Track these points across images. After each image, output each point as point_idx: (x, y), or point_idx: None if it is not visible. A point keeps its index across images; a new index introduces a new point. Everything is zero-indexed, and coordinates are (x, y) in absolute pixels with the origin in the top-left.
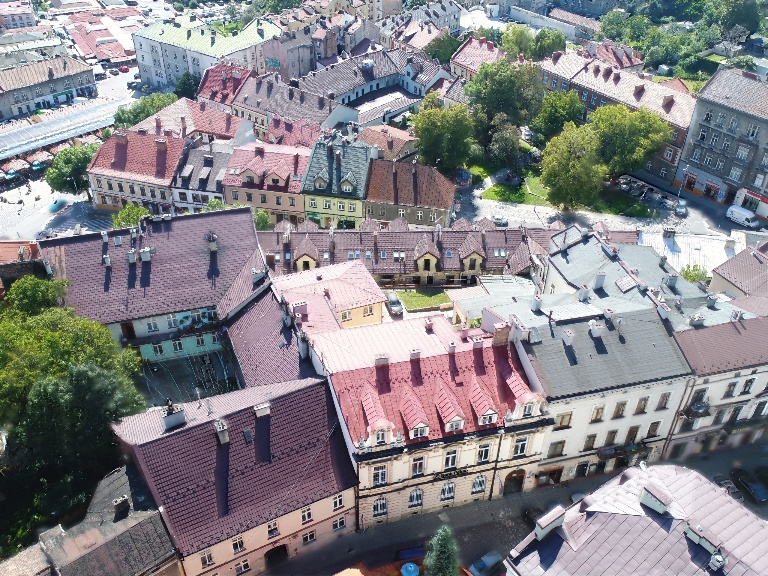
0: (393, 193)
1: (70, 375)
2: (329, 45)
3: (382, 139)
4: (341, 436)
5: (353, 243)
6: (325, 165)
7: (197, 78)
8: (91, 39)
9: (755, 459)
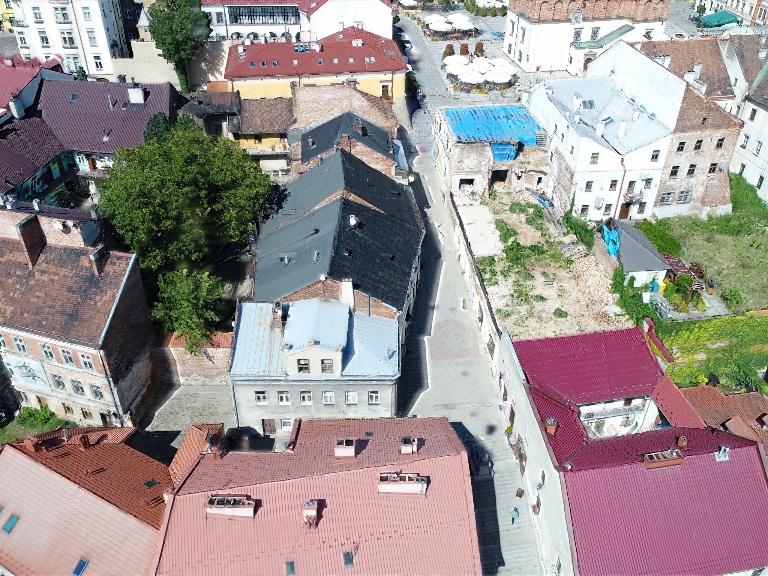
0: None
1: None
2: None
3: None
4: None
5: None
6: None
7: None
8: None
9: None
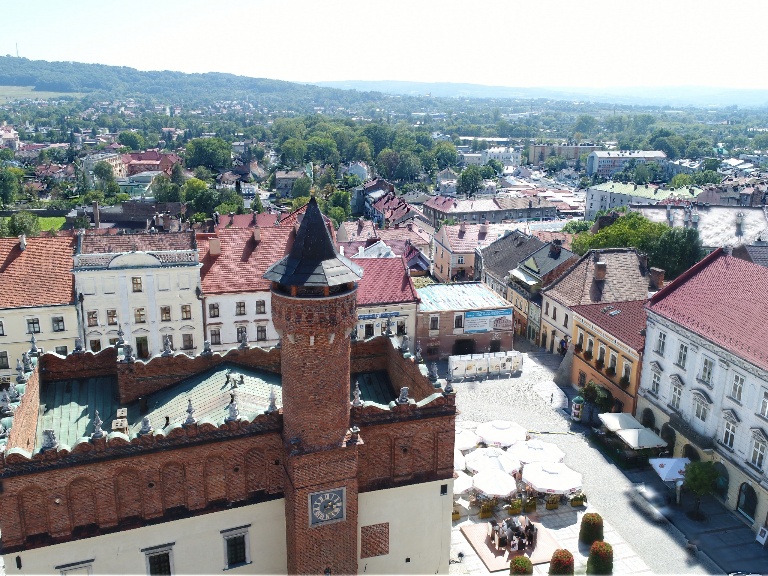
0: None
1: (684, 232)
2: (755, 199)
3: None
4: None
5: None
6: None
7: None
8: None
9: None
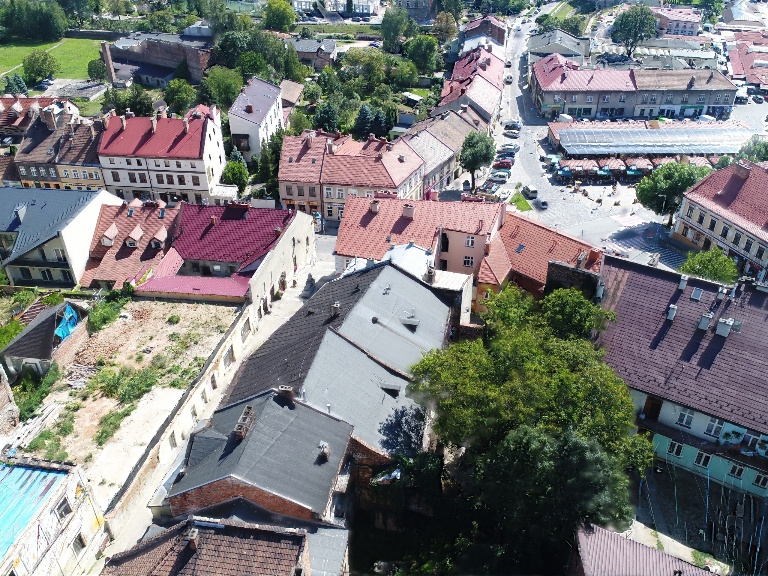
0: None
1: (564, 440)
2: None
3: None
4: None
5: None
6: None
7: None
8: (749, 60)
9: None
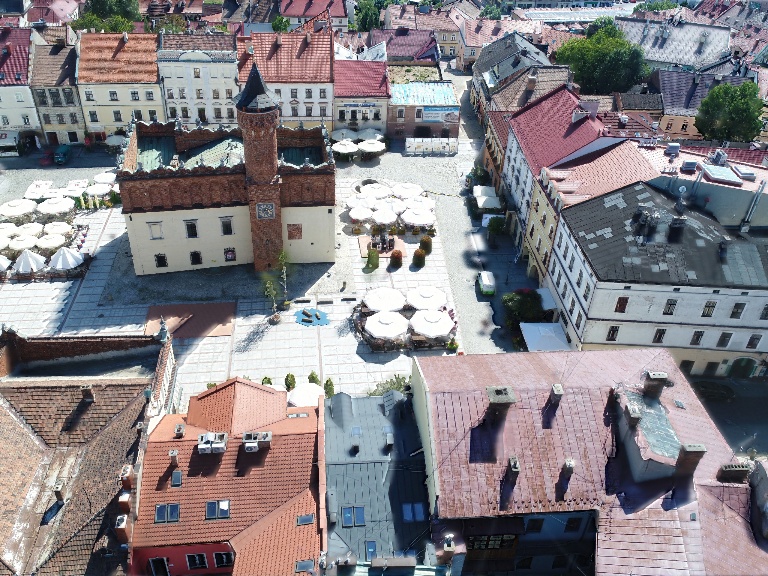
0: None
1: (630, 52)
2: None
3: None
4: None
5: None
6: None
7: (691, 8)
8: None
9: None
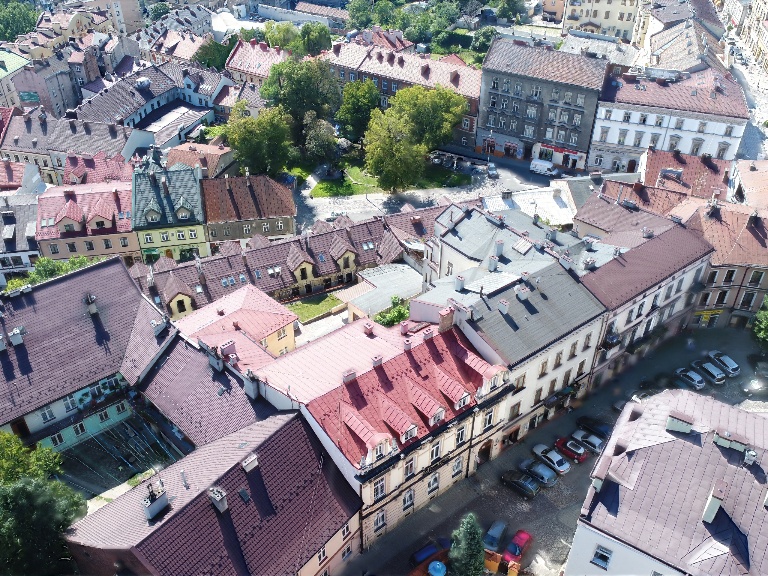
0: (233, 210)
1: (2, 498)
2: (90, 68)
3: (193, 158)
4: (332, 464)
5: (223, 270)
6: (152, 196)
7: None
8: None
9: (651, 369)
